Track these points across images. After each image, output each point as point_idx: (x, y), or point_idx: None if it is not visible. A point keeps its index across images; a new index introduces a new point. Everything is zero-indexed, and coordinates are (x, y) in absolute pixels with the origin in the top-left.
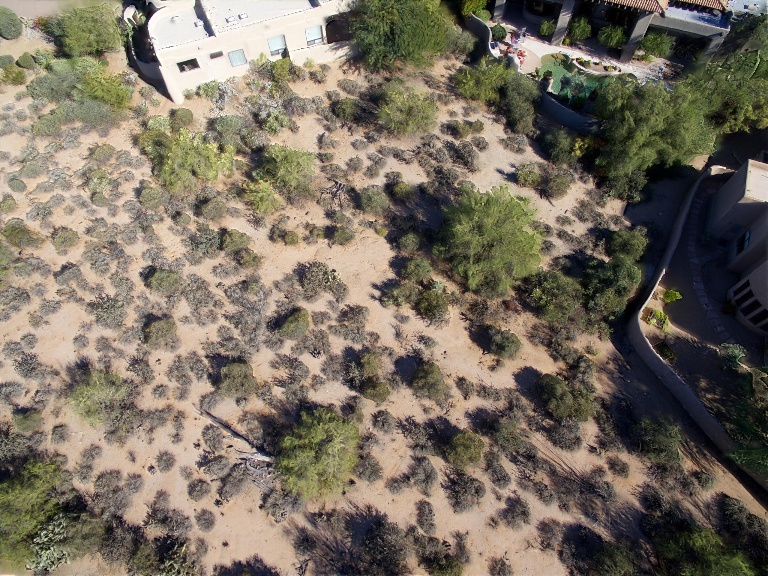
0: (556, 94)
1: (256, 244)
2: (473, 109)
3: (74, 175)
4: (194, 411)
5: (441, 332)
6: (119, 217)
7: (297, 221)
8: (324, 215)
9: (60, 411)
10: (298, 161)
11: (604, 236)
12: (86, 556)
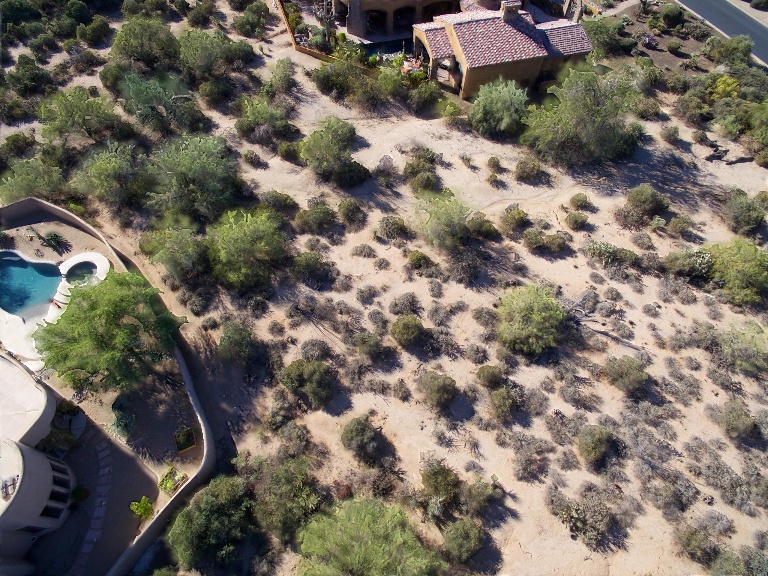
0: None
1: None
2: None
3: None
4: (652, 350)
5: None
6: None
7: None
8: None
9: None
10: None
11: None
12: None
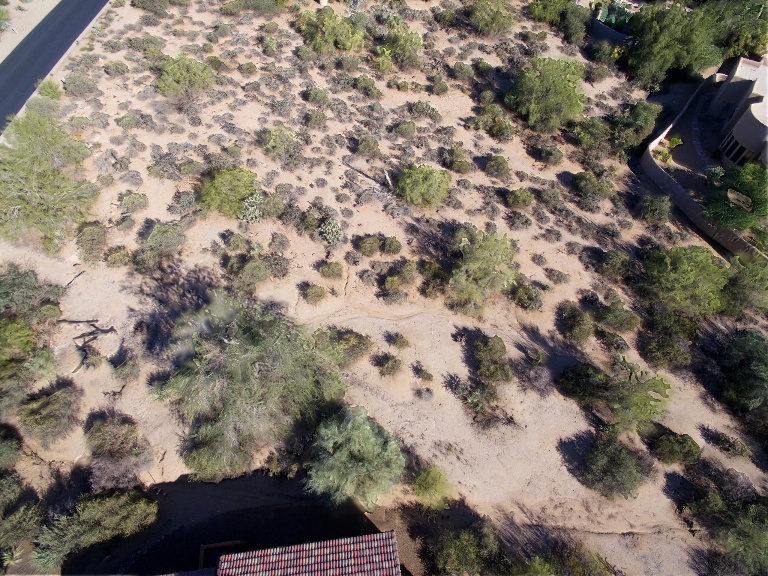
0: (603, 22)
1: (378, 88)
2: (540, 26)
3: (250, 38)
4: (339, 162)
5: (506, 148)
6: (282, 64)
7: (406, 80)
8: (426, 79)
9: (252, 152)
10: (411, 40)
11: (630, 107)
12: (271, 222)
